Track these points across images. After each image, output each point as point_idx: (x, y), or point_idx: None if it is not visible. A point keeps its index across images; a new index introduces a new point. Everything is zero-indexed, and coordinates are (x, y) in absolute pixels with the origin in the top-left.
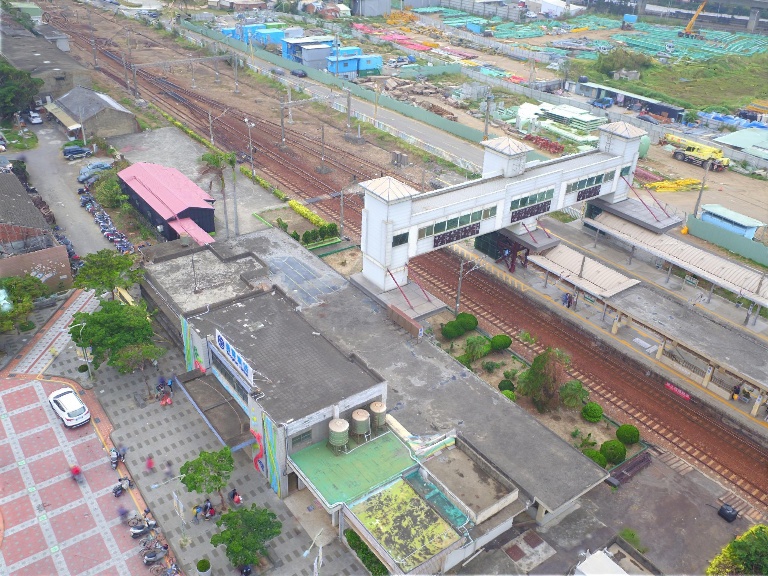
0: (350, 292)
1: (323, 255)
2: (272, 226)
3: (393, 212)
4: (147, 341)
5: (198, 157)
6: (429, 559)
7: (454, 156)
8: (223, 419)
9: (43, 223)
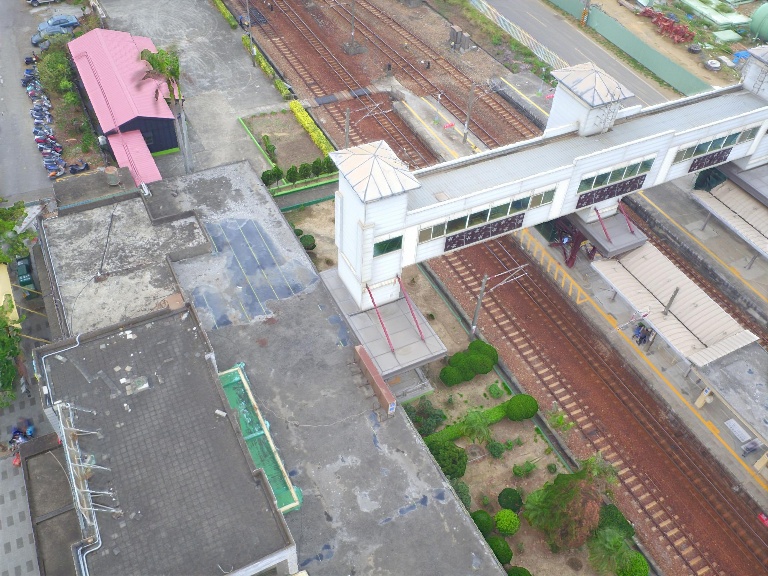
0: (316, 299)
1: (313, 202)
2: (257, 144)
3: (375, 212)
4: (1, 369)
5: (195, 14)
6: None
7: (535, 41)
8: (59, 543)
9: None
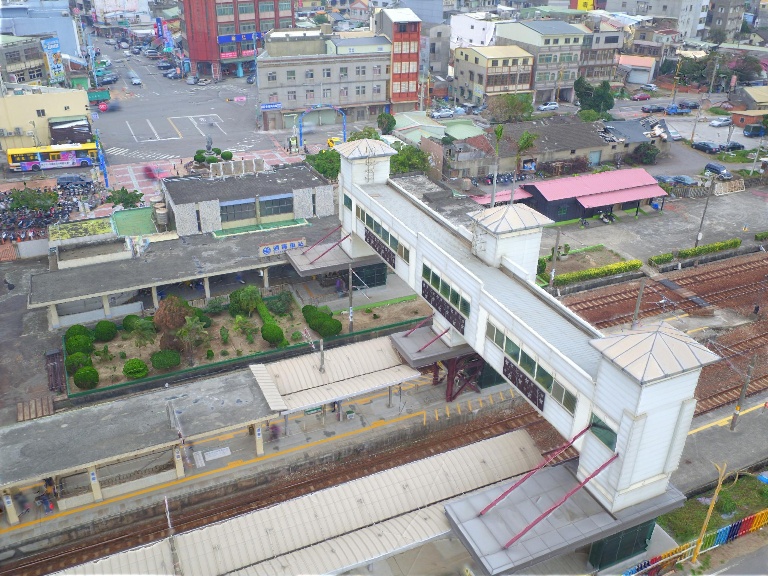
0: None
1: None
2: None
3: None
4: None
5: (764, 223)
6: (48, 231)
7: None
8: None
9: (507, 153)
